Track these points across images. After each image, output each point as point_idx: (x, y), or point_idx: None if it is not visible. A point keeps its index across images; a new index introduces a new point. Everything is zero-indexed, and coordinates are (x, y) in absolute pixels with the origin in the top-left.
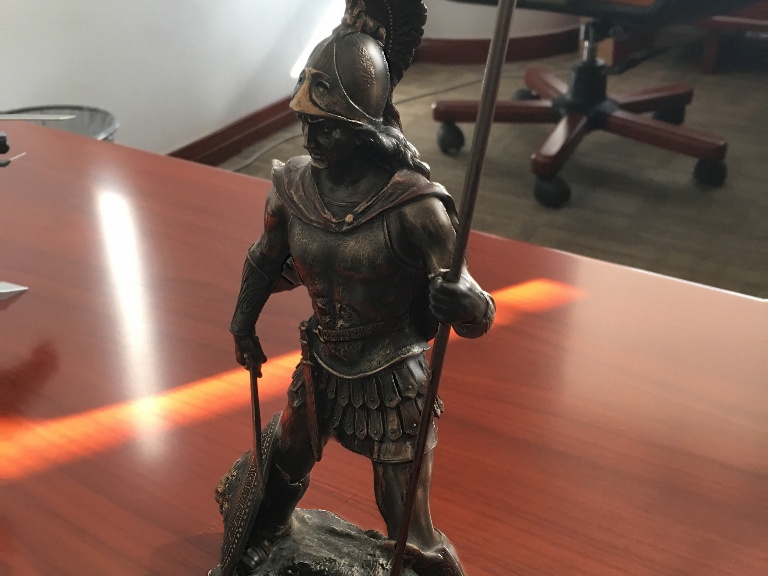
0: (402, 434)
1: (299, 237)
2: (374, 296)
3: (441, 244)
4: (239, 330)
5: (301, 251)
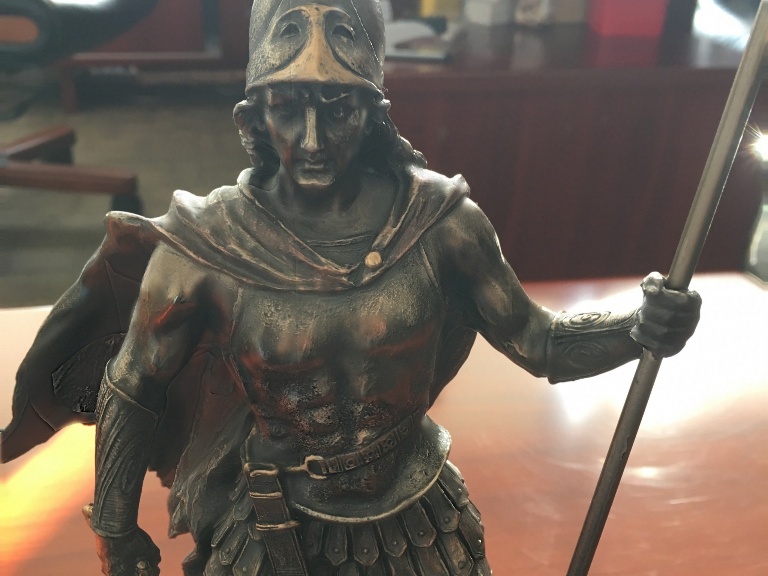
0: (473, 562)
1: (273, 318)
2: (413, 372)
3: (498, 261)
4: (123, 526)
5: (284, 340)
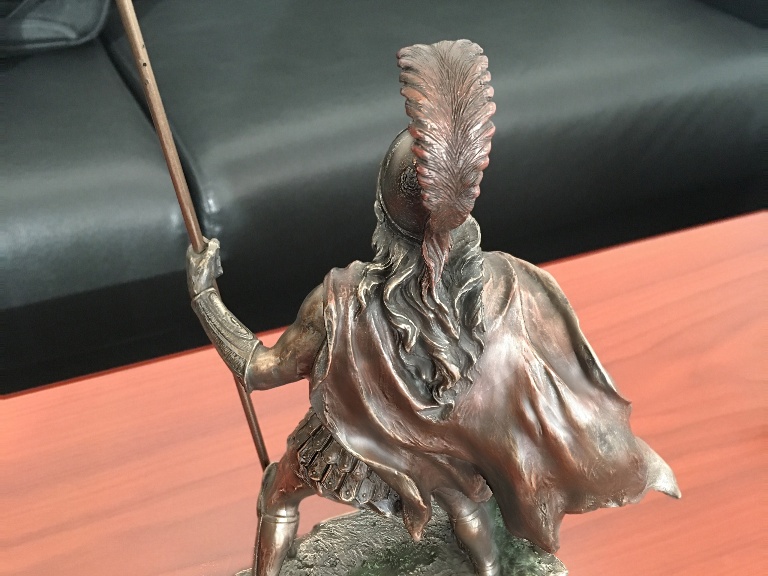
0: None
1: None
2: None
3: None
4: None
5: None
